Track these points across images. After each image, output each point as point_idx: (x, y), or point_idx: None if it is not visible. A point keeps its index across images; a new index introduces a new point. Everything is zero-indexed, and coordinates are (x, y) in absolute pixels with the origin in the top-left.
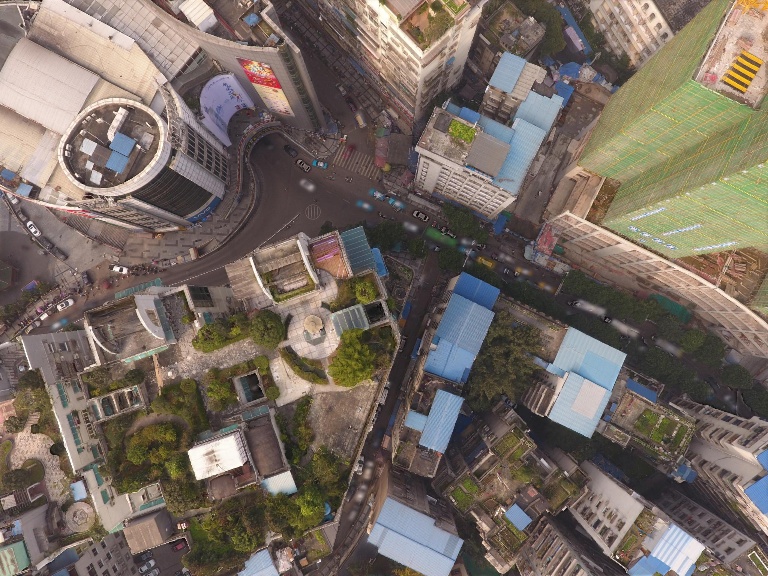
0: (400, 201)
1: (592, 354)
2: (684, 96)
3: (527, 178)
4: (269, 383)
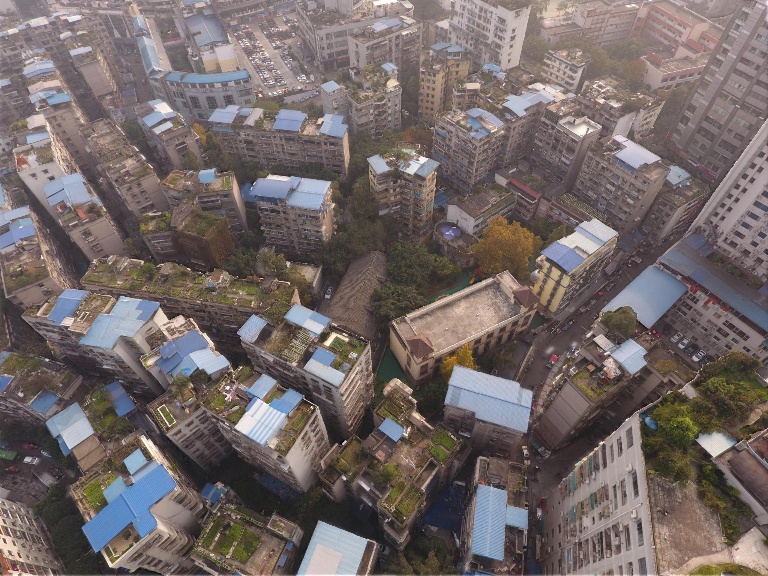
0: None
1: None
2: None
3: None
4: None
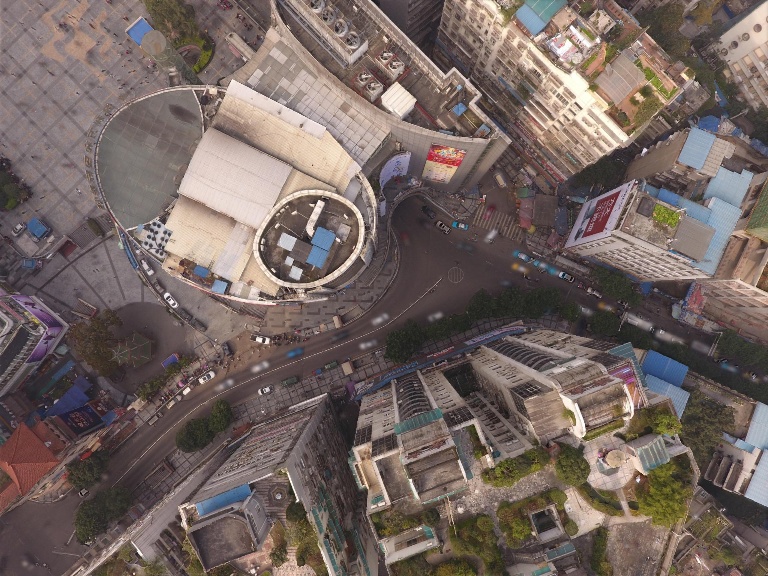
0: (545, 262)
1: None
2: None
3: None
4: (564, 516)
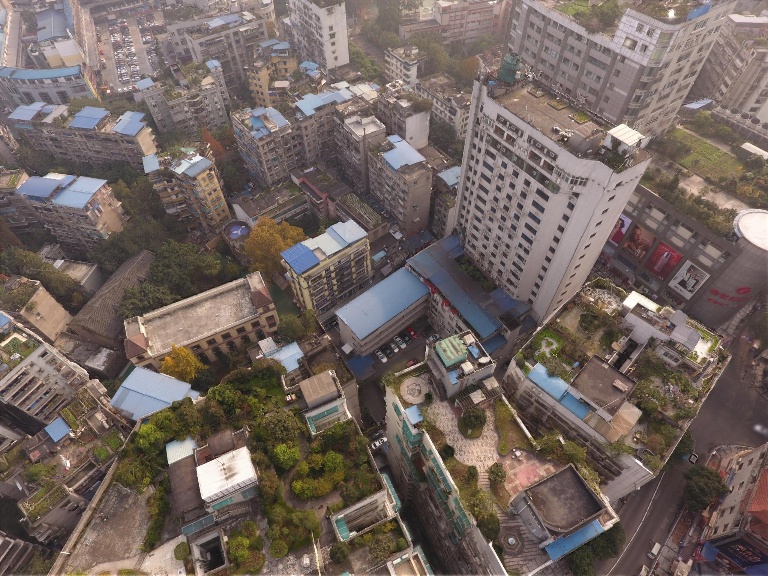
0: None
1: None
2: None
3: None
4: (188, 564)
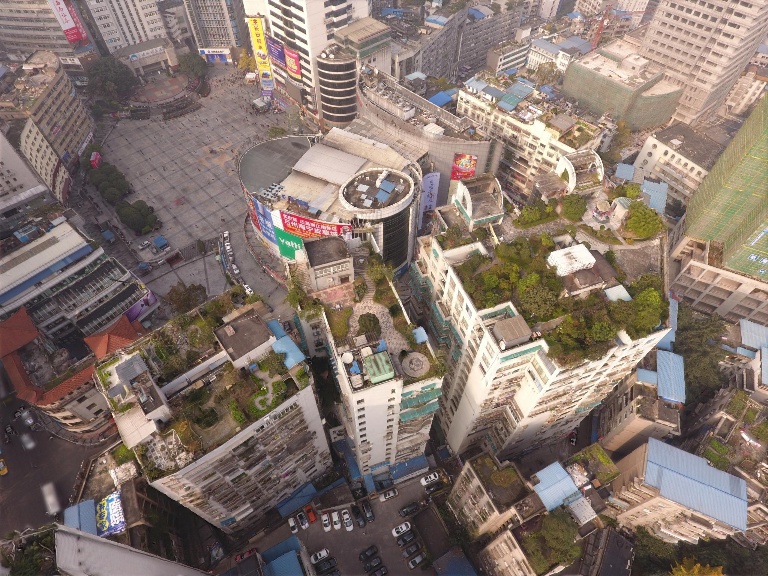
0: None
1: None
2: None
3: None
4: None
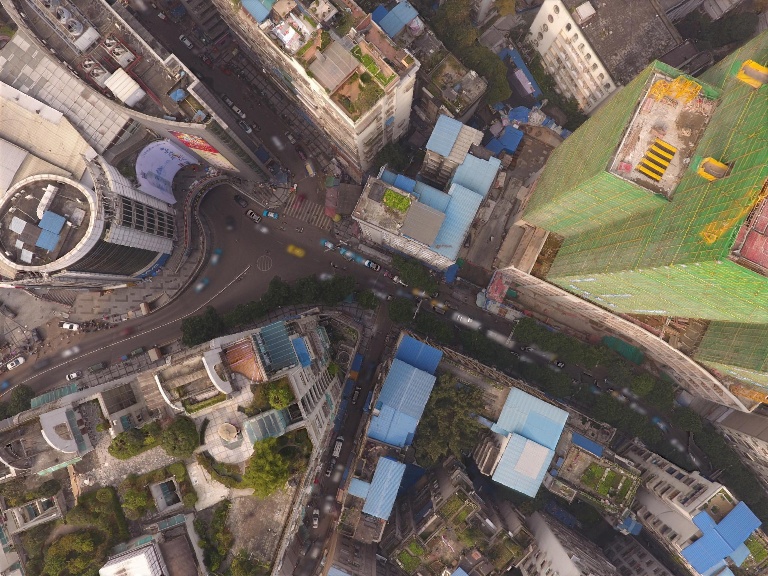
0: (351, 251)
1: (535, 414)
2: (602, 182)
3: (479, 223)
4: (187, 489)
